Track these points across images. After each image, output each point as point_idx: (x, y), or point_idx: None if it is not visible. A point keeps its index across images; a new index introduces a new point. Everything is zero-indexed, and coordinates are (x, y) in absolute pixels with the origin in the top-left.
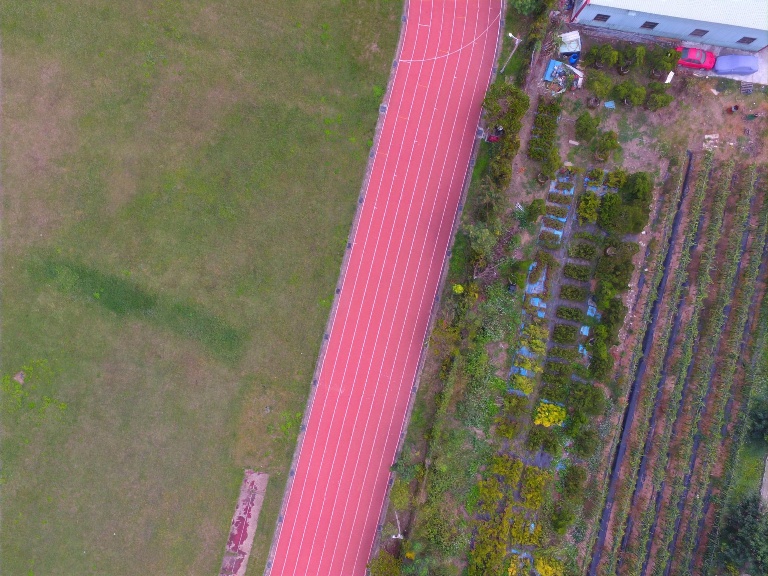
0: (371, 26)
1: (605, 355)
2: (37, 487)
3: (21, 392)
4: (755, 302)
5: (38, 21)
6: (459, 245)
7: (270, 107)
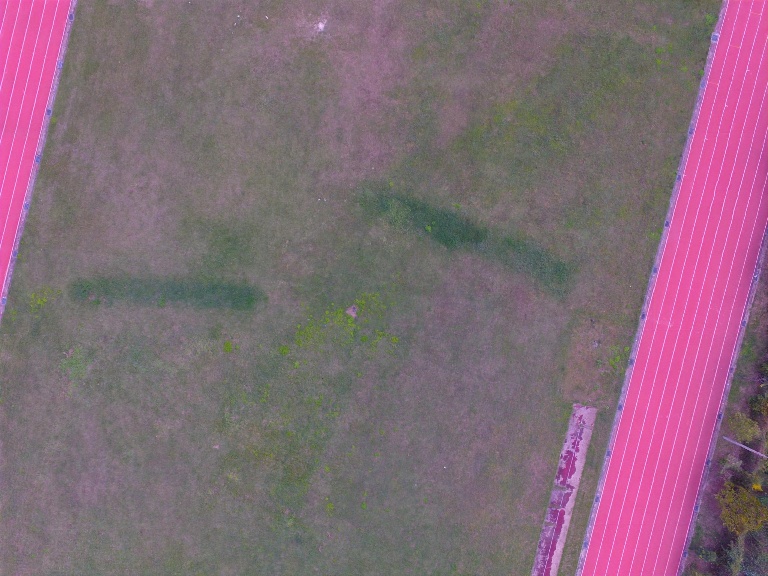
0: None
1: None
2: (369, 420)
3: (353, 326)
4: None
5: None
6: None
7: (602, 37)
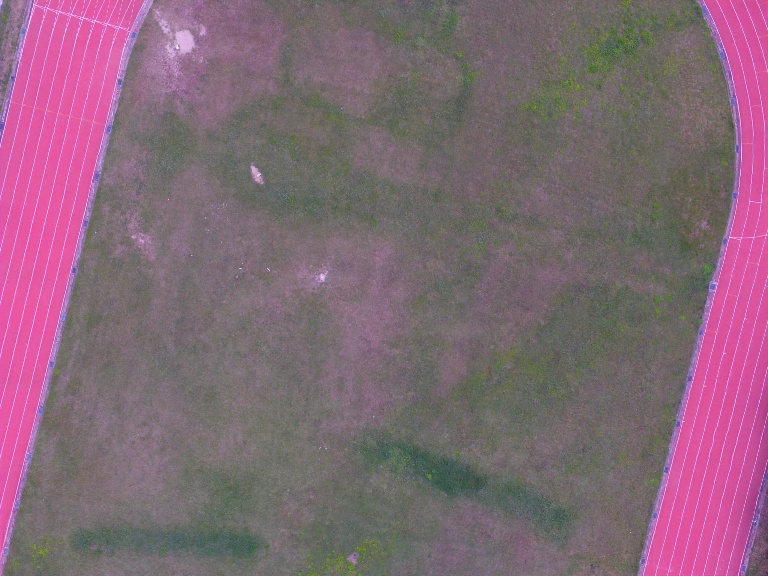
0: (701, 203)
1: None
2: None
3: (354, 573)
4: None
5: (371, 204)
6: None
7: (600, 287)
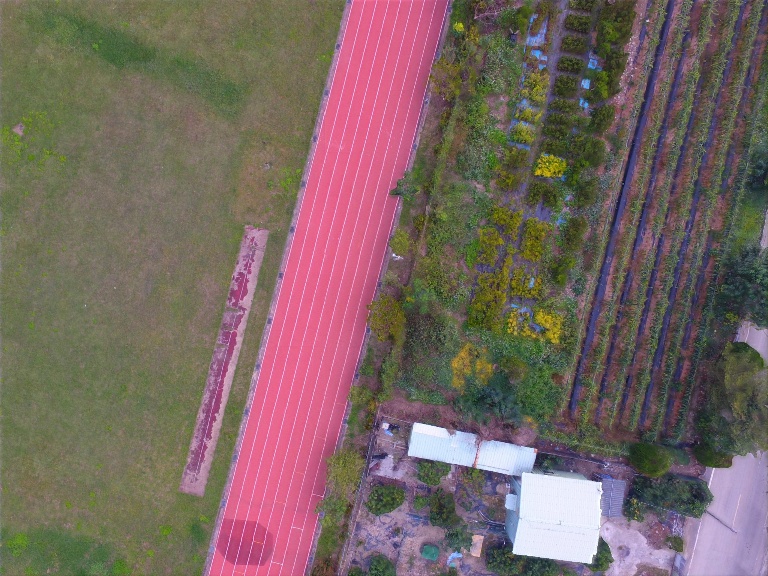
0: None
1: (606, 94)
2: (37, 239)
3: (20, 144)
4: (757, 54)
5: None
6: (460, 0)
7: None
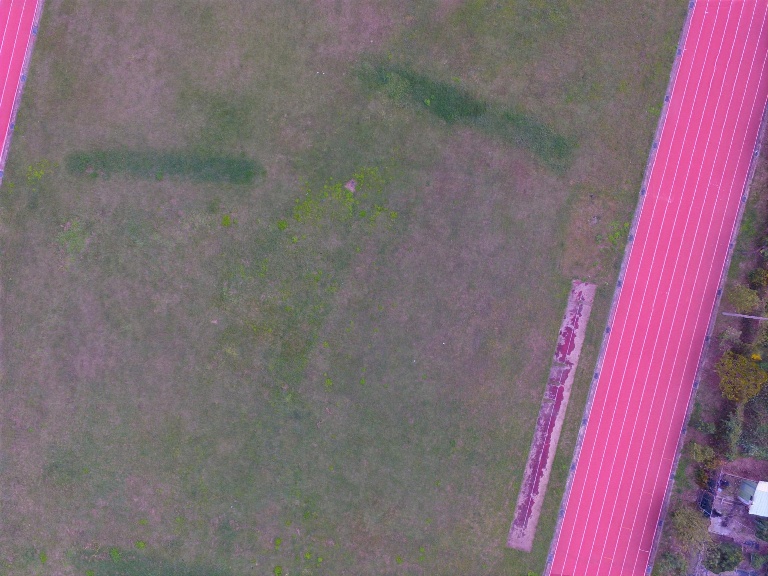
0: None
1: None
2: (368, 295)
3: (352, 200)
4: None
5: None
6: None
7: None
